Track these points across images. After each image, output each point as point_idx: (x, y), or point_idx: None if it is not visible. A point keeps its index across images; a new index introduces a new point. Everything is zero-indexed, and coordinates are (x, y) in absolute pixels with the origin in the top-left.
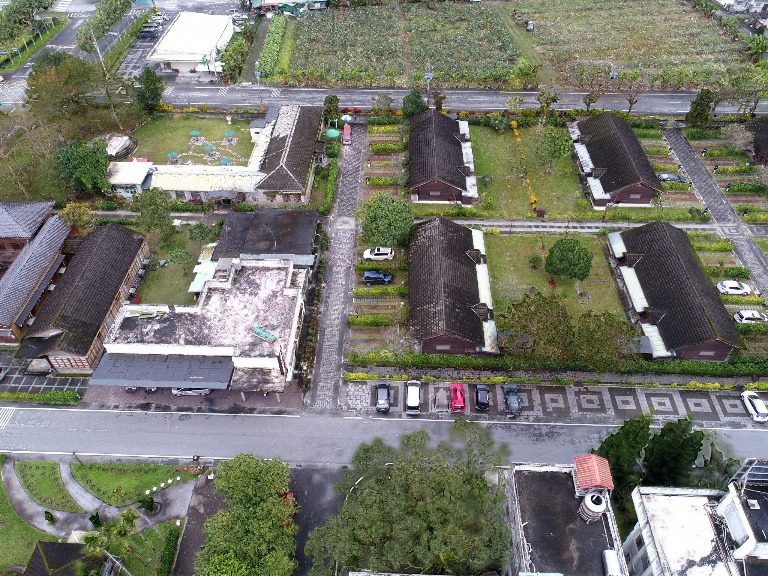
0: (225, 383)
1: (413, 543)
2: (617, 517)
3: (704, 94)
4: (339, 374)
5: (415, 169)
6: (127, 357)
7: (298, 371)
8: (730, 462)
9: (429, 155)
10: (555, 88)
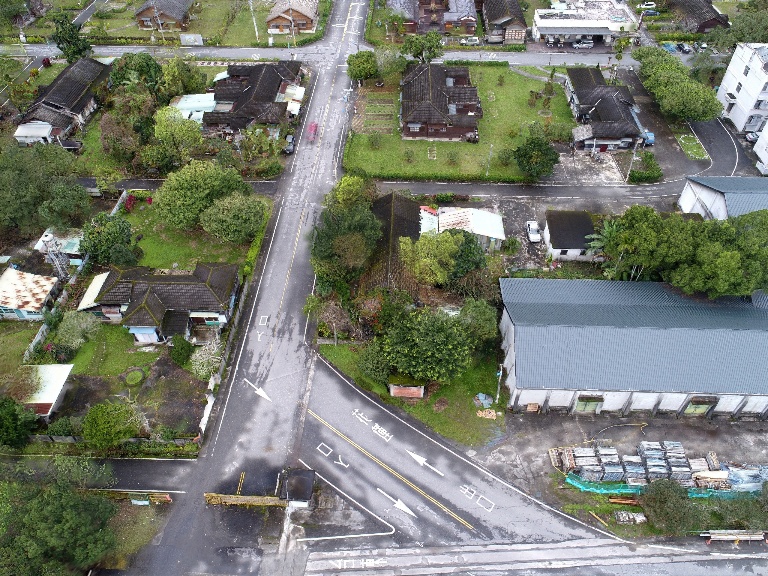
0: (611, 33)
1: (765, 29)
2: None
3: None
4: (654, 44)
5: None
6: (551, 27)
7: None
8: None
9: None
10: None
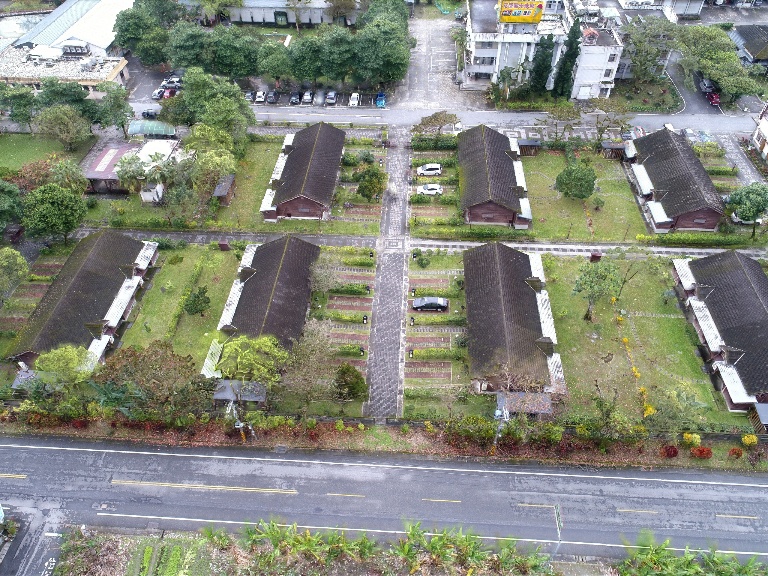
0: None
1: None
2: (549, 99)
3: (352, 368)
4: None
5: (766, 282)
6: None
7: (752, 148)
8: (511, 68)
9: (760, 289)
10: (578, 567)
